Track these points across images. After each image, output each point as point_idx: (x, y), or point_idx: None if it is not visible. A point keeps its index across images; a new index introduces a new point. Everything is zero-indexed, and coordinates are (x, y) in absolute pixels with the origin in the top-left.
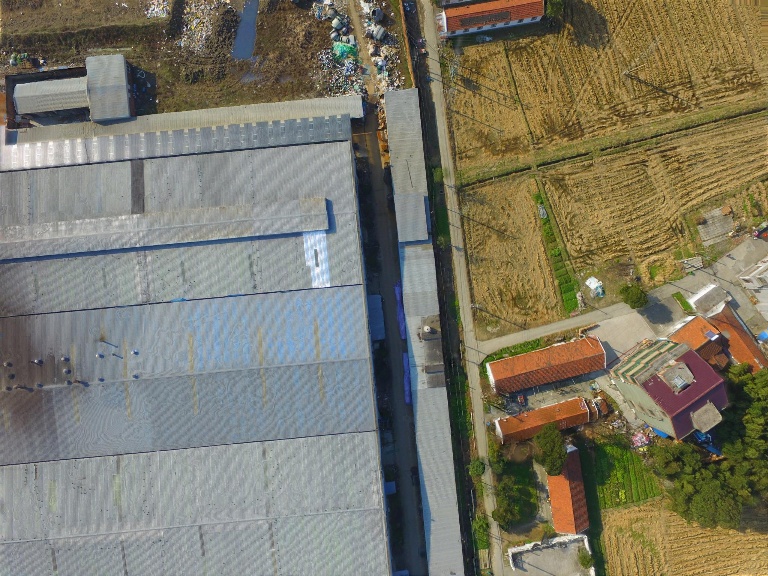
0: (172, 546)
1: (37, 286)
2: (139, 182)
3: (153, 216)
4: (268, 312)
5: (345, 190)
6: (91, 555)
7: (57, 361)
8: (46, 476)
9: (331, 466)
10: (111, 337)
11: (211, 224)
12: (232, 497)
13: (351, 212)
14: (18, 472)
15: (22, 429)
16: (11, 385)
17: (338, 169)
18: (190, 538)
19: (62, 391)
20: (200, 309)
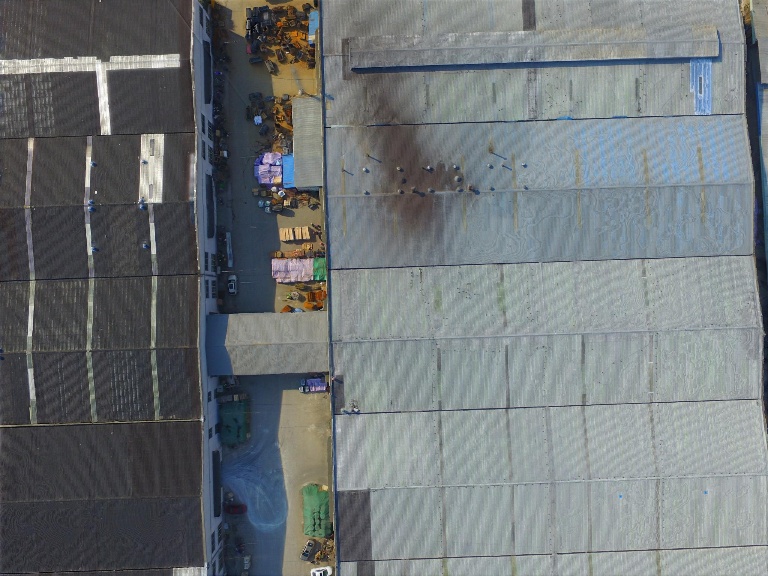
0: (555, 353)
1: (428, 96)
2: (529, 2)
3: (549, 33)
4: (652, 135)
5: (731, 21)
6: (476, 357)
7: (447, 169)
8: (431, 280)
9: (709, 286)
10: (500, 149)
11: (606, 44)
12: (614, 309)
13: (738, 42)
14: (404, 275)
15: (411, 233)
16: (403, 189)
17: (723, 2)
18: (572, 346)
19: (453, 197)
20: (585, 128)
